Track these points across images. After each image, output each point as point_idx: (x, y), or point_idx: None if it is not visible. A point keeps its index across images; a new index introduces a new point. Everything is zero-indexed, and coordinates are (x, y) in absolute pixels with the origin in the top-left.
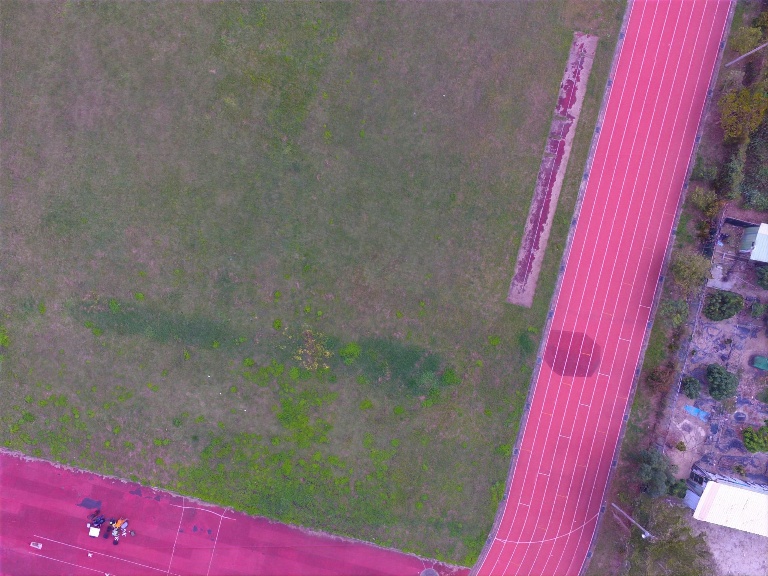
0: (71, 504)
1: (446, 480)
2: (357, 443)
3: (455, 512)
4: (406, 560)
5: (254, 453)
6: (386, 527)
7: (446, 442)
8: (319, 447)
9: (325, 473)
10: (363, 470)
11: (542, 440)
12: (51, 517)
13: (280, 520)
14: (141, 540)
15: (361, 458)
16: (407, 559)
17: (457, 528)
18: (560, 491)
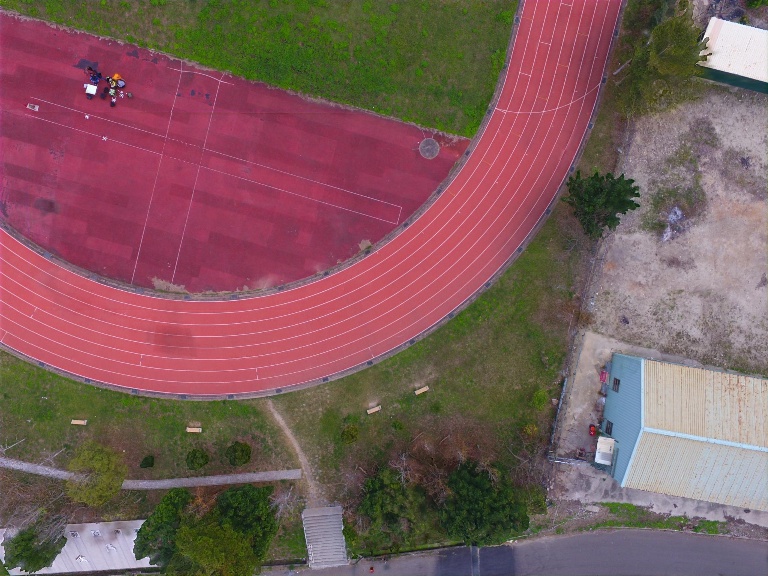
0: (67, 65)
1: (446, 47)
2: (356, 8)
3: (455, 81)
4: (406, 129)
5: (252, 15)
6: (386, 95)
7: (446, 8)
8: (318, 11)
9: (324, 37)
10: (362, 35)
11: (543, 8)
12: (47, 78)
13: (279, 85)
14: (138, 104)
15: (360, 23)
16: (407, 128)
17: (457, 97)
18: (561, 60)
